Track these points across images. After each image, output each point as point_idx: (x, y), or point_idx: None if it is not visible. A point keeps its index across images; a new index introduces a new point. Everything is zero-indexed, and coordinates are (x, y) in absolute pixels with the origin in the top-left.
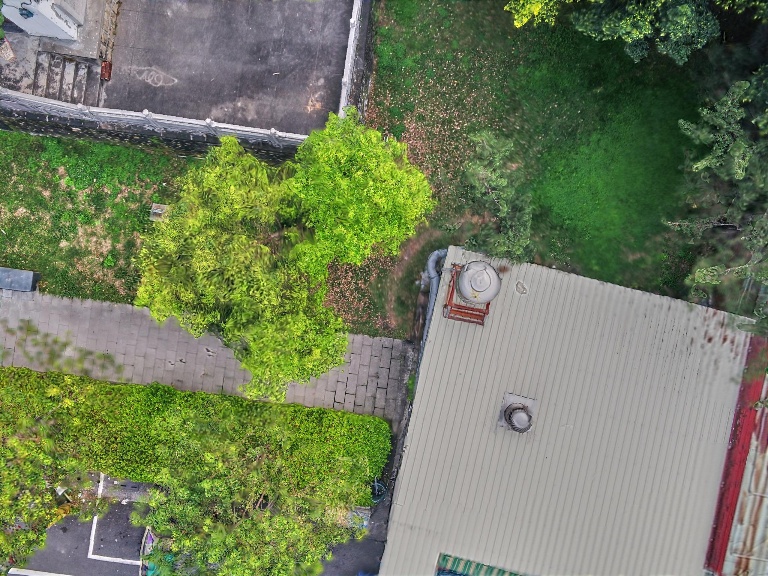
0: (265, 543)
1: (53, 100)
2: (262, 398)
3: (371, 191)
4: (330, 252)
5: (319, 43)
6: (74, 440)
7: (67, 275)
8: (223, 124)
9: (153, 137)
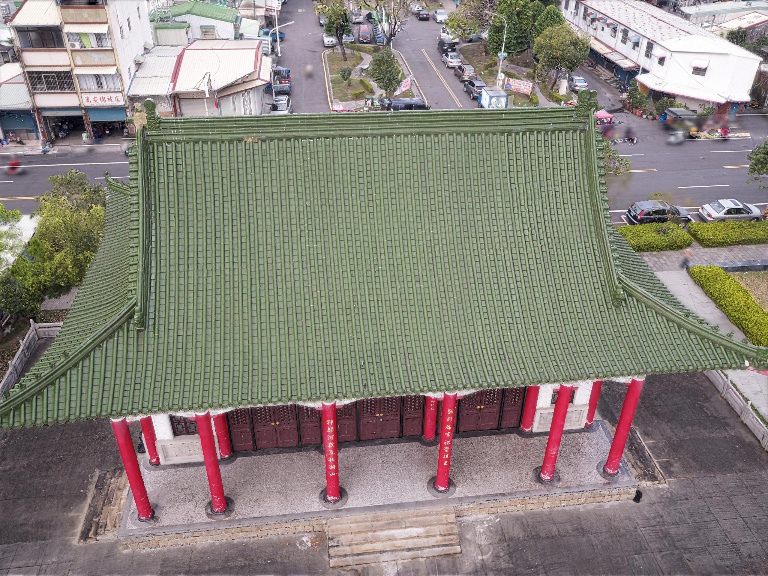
0: None
1: None
2: None
3: None
4: None
5: None
6: None
7: None
8: None
9: None
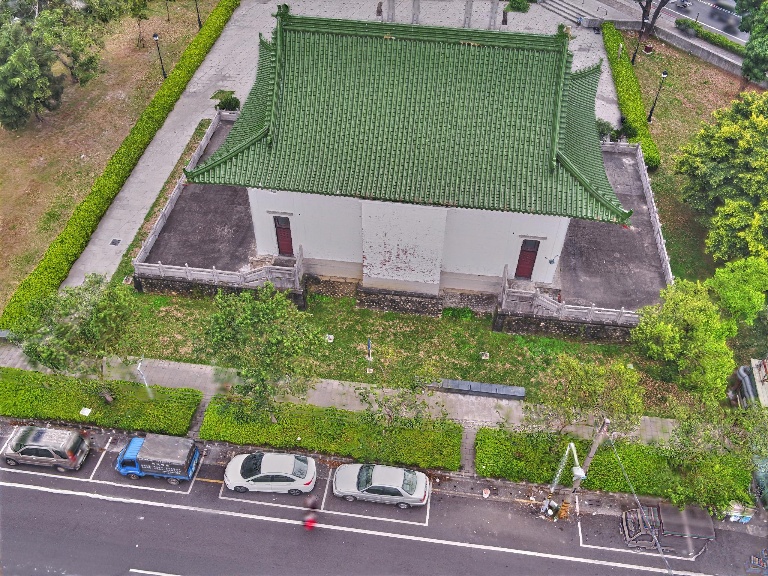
0: (753, 415)
1: (552, 300)
2: (713, 381)
3: (761, 270)
4: (738, 306)
5: (652, 291)
6: (568, 465)
7: (538, 394)
8: (627, 311)
9: (584, 325)
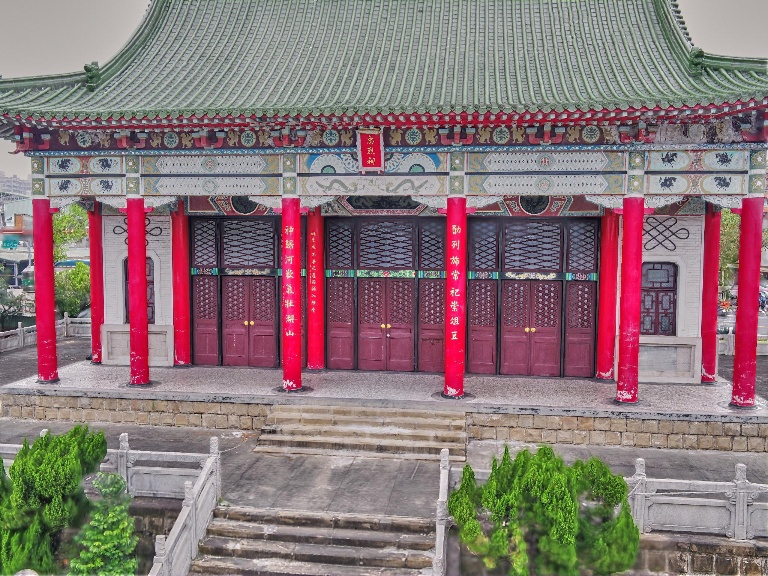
0: None
1: None
2: None
3: None
4: None
5: None
6: None
7: None
8: None
9: None
